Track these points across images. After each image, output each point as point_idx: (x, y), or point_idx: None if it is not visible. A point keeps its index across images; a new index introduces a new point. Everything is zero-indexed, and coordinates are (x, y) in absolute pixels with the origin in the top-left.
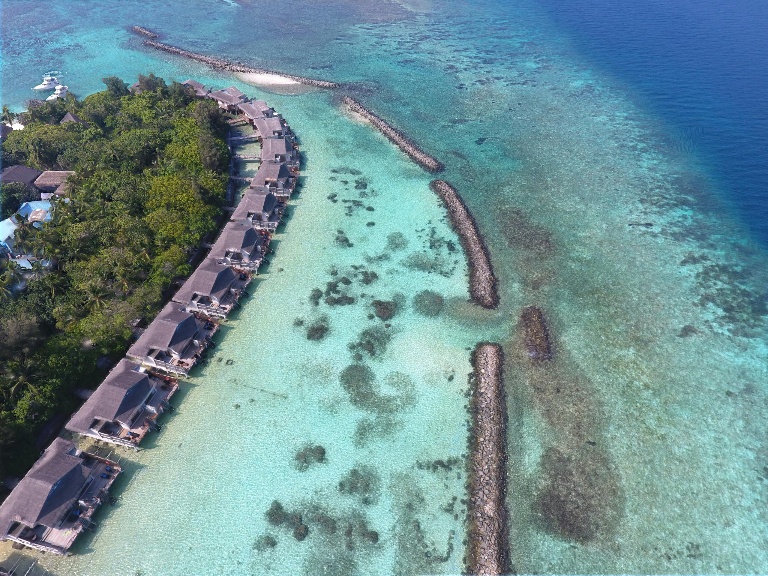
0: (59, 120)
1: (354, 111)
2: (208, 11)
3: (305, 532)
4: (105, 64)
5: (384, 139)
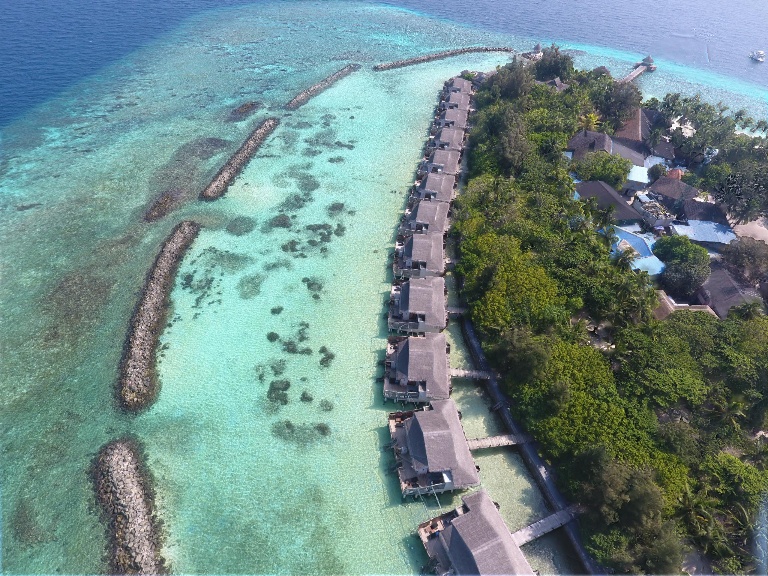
0: None
1: None
2: None
3: (336, 142)
4: None
5: None
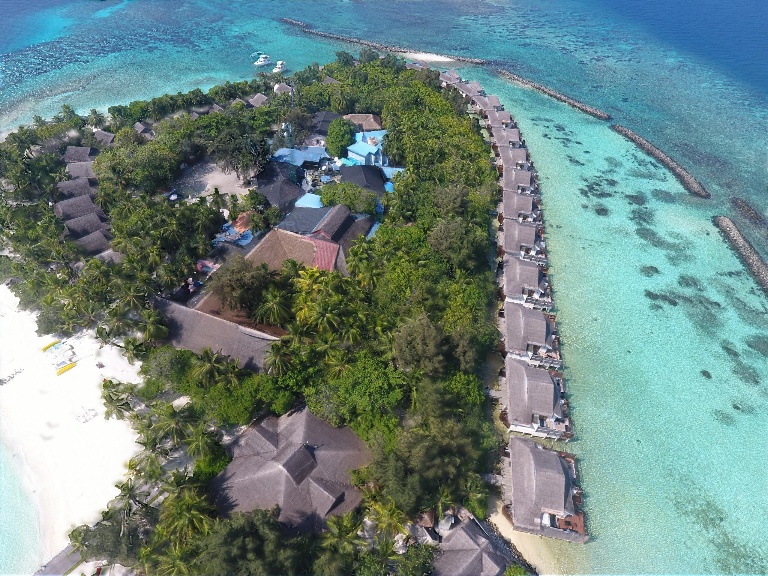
0: (309, 84)
1: (515, 80)
2: (329, 6)
3: (676, 302)
4: (286, 47)
5: (552, 99)
